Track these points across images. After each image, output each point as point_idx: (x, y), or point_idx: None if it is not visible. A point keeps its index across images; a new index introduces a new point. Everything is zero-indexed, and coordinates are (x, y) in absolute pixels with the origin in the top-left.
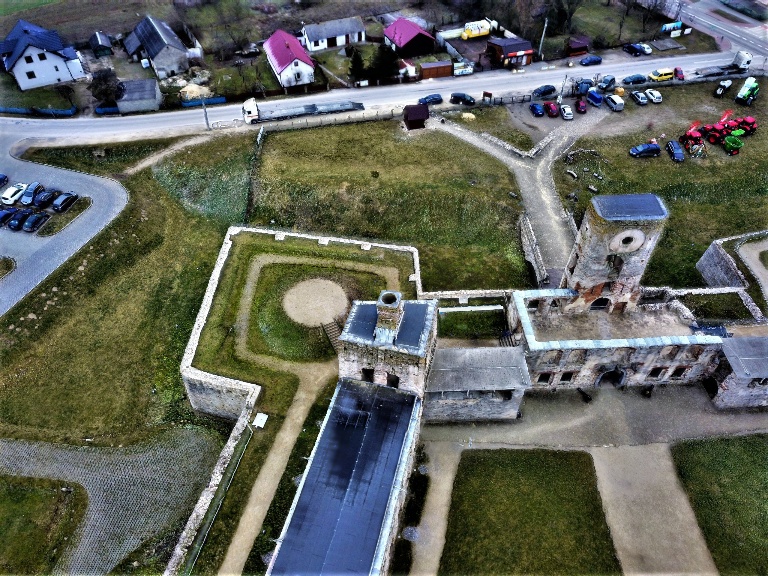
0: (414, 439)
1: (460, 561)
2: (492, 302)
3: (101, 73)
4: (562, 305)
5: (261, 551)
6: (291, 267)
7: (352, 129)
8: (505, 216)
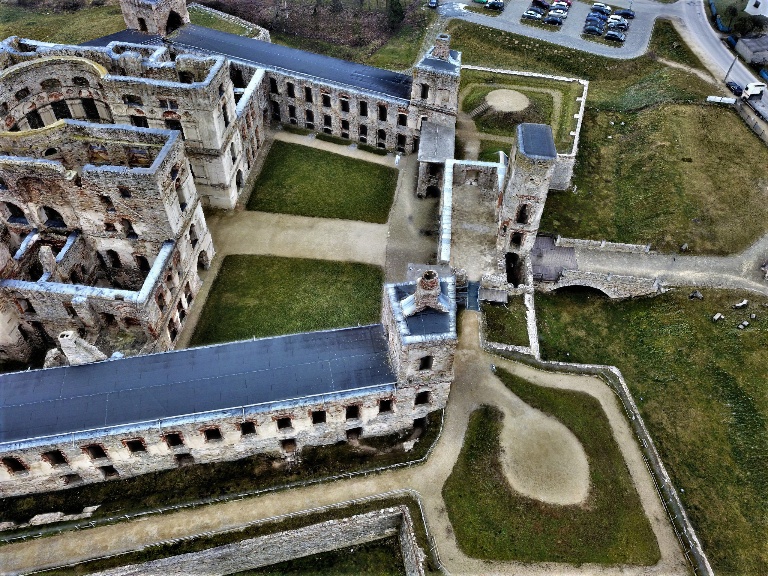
0: (393, 118)
1: (334, 159)
2: None
3: (760, 17)
4: None
5: None
6: (549, 104)
7: (762, 153)
8: (653, 242)
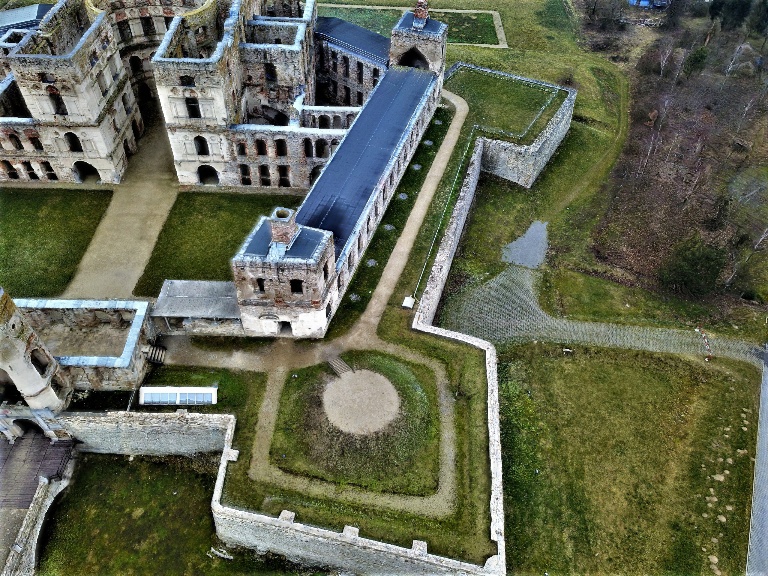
0: None
1: None
2: (147, 409)
3: None
4: (73, 374)
5: (396, 230)
6: (397, 487)
7: None
8: None
